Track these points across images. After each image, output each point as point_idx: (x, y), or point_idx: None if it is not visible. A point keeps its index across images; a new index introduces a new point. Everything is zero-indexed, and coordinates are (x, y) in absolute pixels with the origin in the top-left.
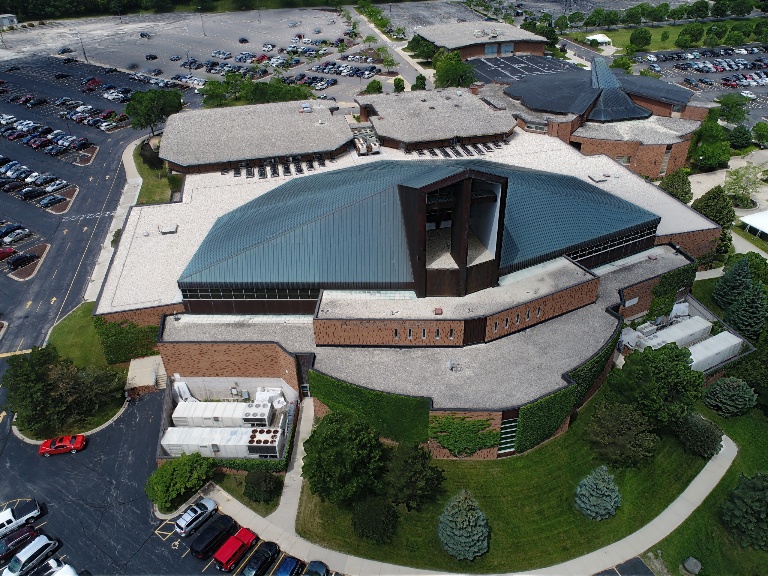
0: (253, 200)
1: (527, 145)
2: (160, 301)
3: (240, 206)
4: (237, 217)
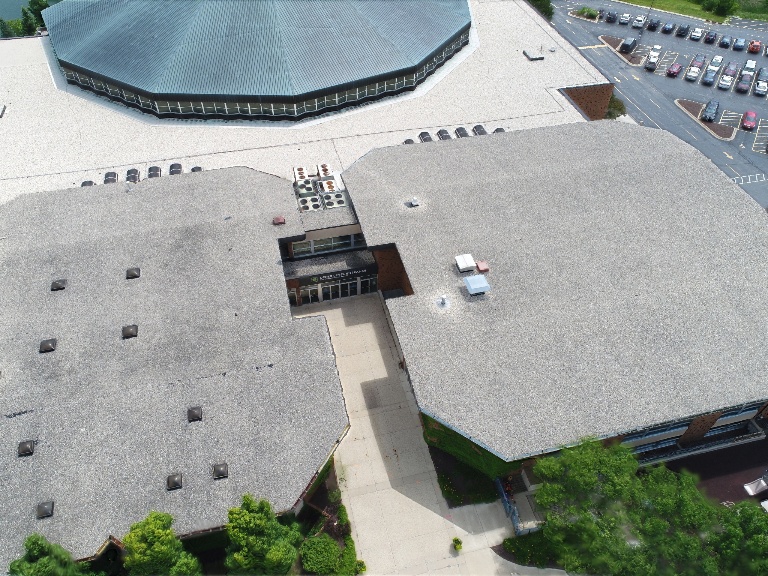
0: (446, 33)
1: (3, 202)
2: (479, 1)
3: (457, 30)
4: (445, 3)
